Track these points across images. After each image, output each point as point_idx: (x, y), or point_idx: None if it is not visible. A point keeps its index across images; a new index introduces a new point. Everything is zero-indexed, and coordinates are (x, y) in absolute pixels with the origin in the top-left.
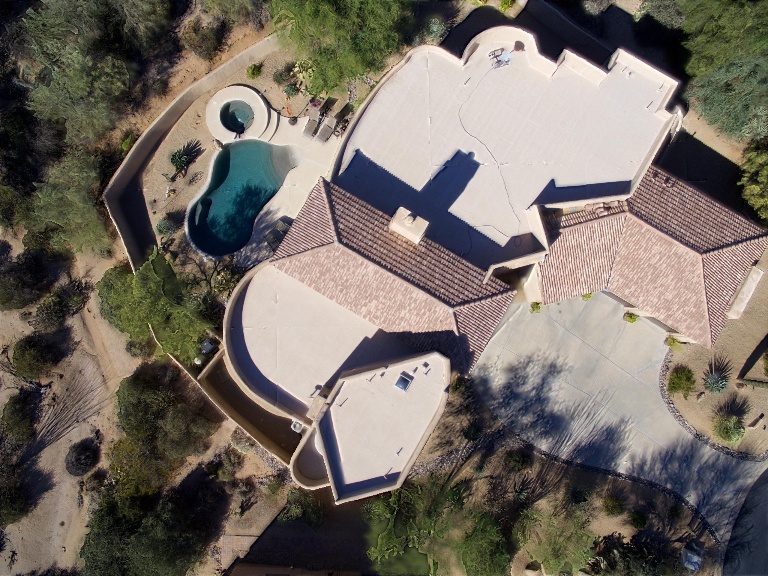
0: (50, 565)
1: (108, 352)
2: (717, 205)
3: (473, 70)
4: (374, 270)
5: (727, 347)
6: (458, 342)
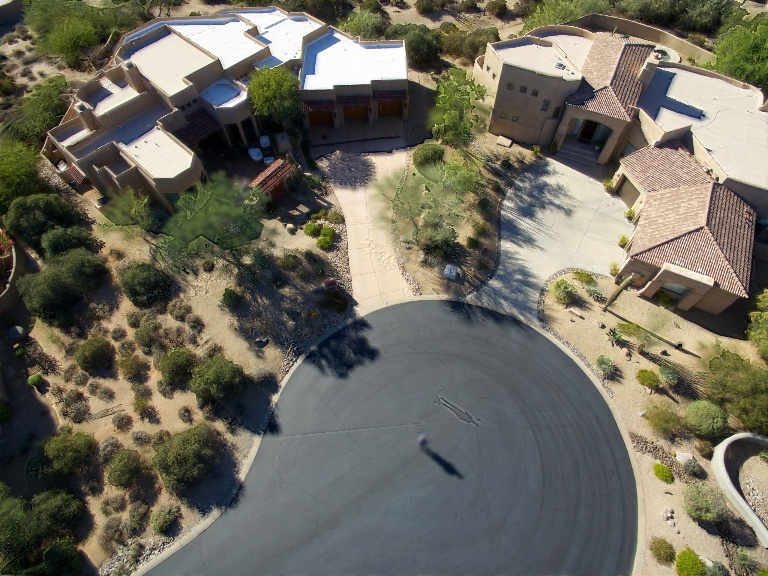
0: (393, 24)
1: (506, 32)
2: (751, 256)
3: (760, 115)
4: (617, 57)
5: (627, 311)
6: (589, 93)
